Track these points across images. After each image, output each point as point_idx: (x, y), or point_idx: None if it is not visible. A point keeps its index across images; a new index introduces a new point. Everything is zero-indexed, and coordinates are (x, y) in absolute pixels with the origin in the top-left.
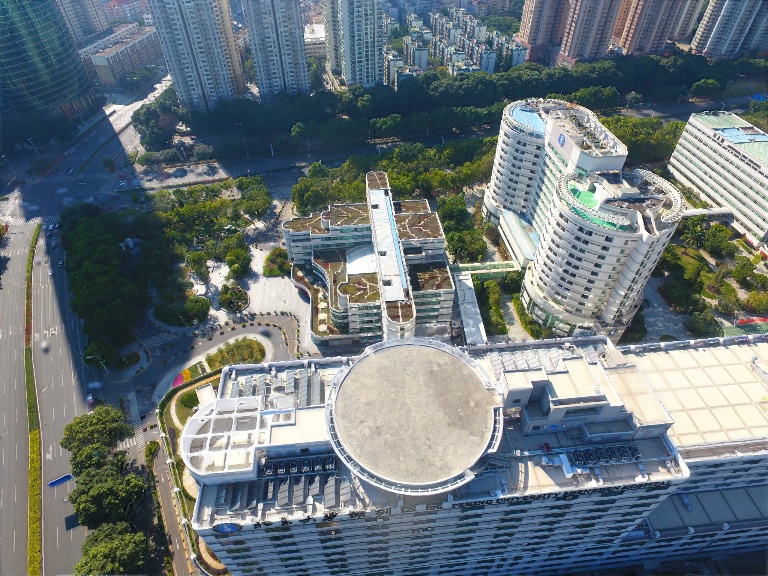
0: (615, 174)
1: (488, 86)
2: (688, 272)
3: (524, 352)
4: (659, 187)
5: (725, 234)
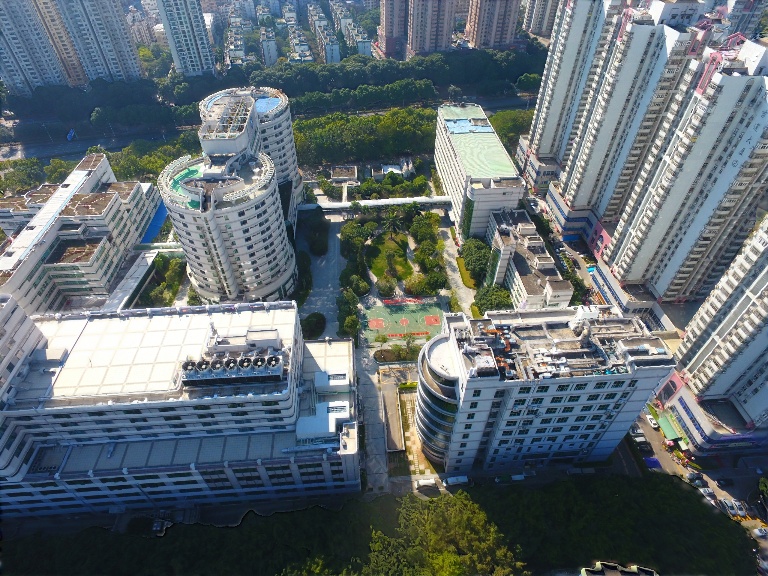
0: (230, 157)
1: (309, 77)
2: (380, 256)
3: None
4: None
5: (430, 221)
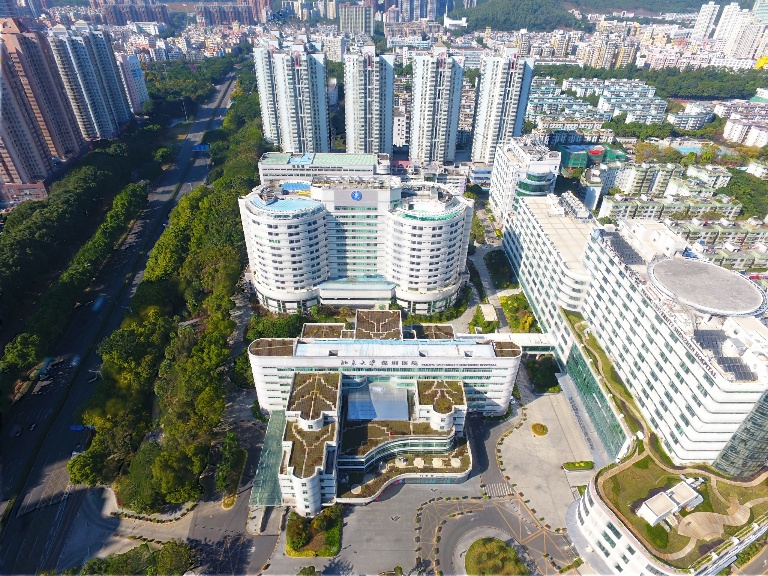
0: (403, 193)
1: (32, 245)
2: None
3: (618, 253)
4: None
5: None
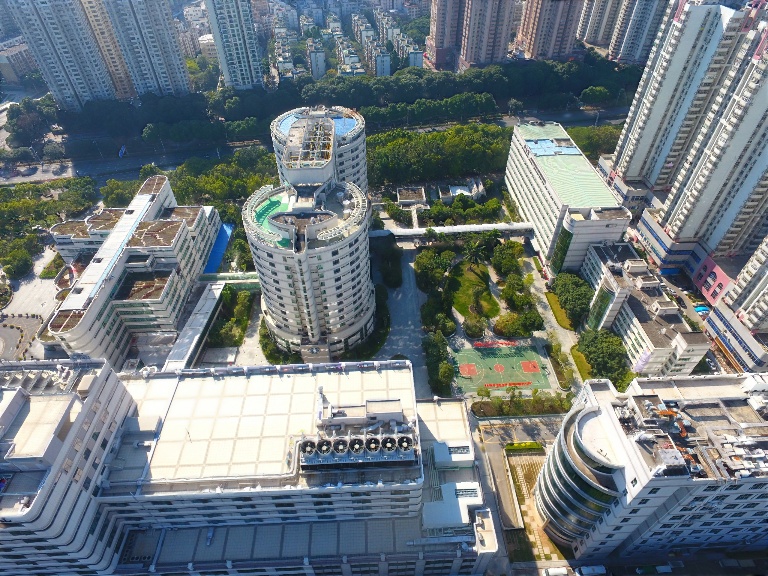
0: (316, 187)
1: (363, 90)
2: (461, 289)
3: (12, 372)
4: (354, 202)
5: (513, 251)
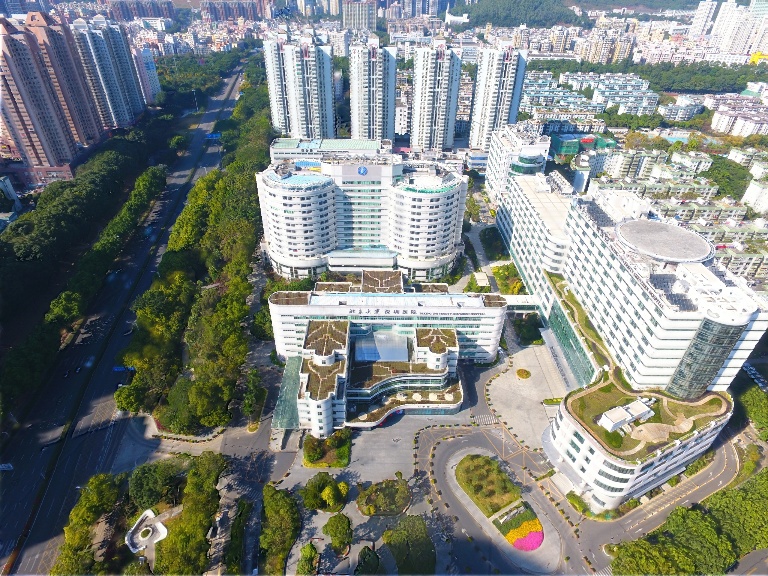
0: None
1: (65, 219)
2: None
3: (592, 218)
4: None
5: None
